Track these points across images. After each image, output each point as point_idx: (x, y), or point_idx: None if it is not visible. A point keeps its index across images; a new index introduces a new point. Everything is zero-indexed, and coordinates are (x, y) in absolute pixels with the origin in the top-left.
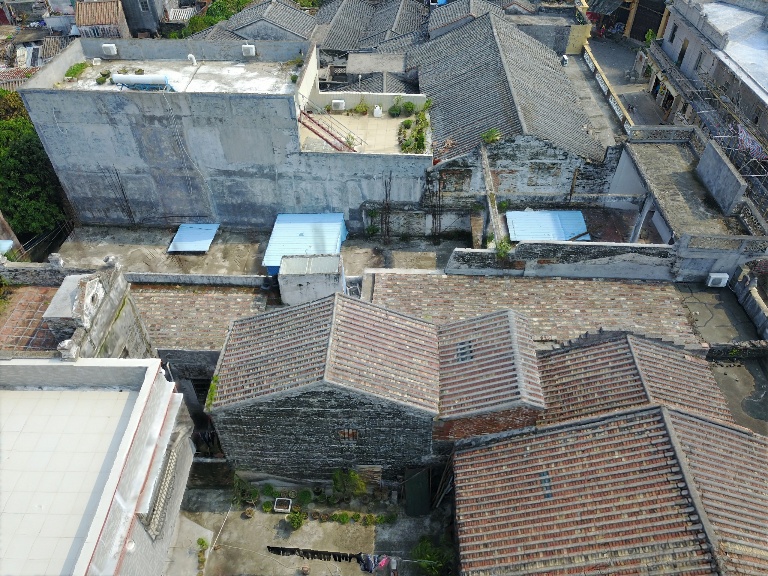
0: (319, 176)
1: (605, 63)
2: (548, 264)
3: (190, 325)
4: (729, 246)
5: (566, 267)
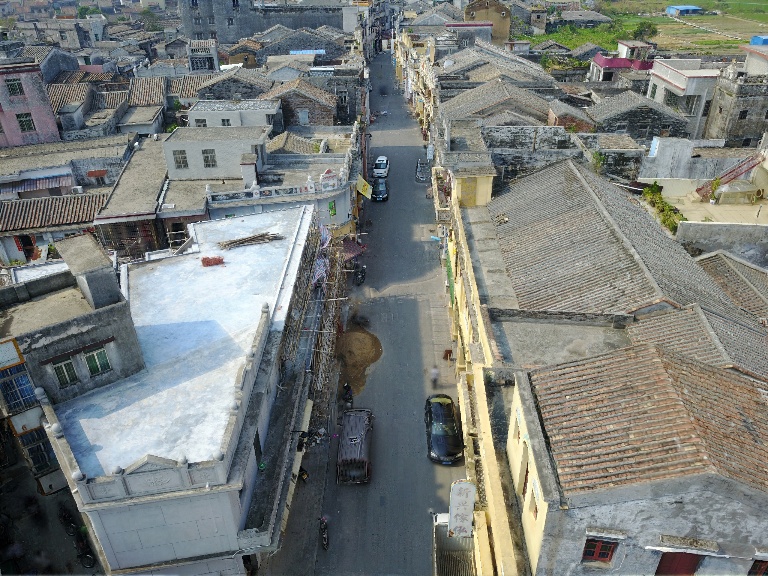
0: None
1: None
2: None
3: None
4: (457, 125)
5: None
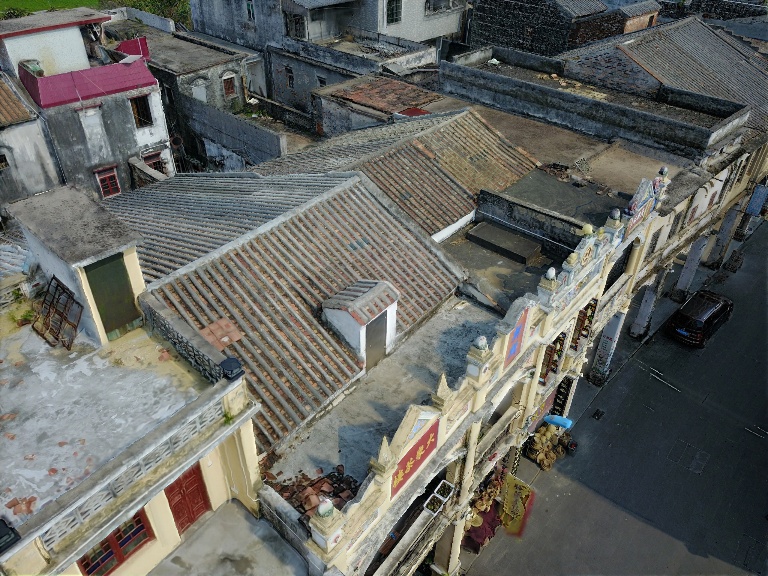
0: (613, 1)
1: None
2: (709, 19)
3: None
4: None
5: (721, 23)
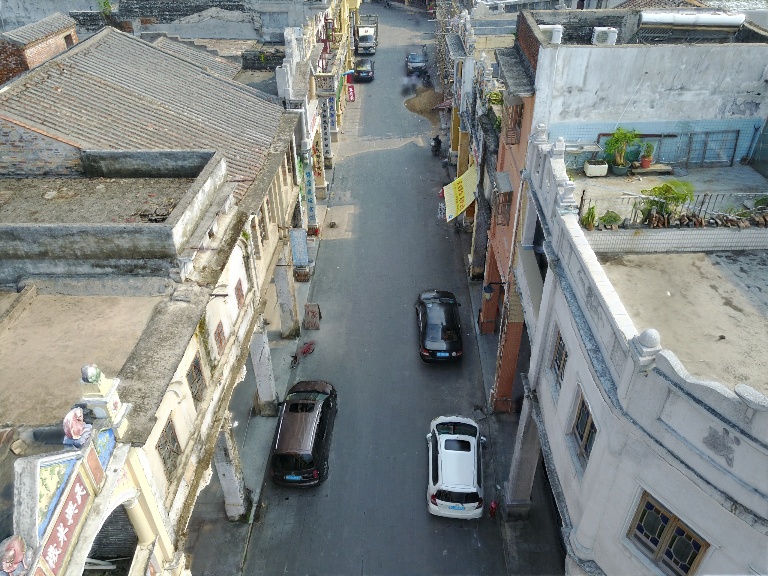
0: None
1: (424, 29)
2: (151, 24)
3: None
4: None
5: (167, 27)
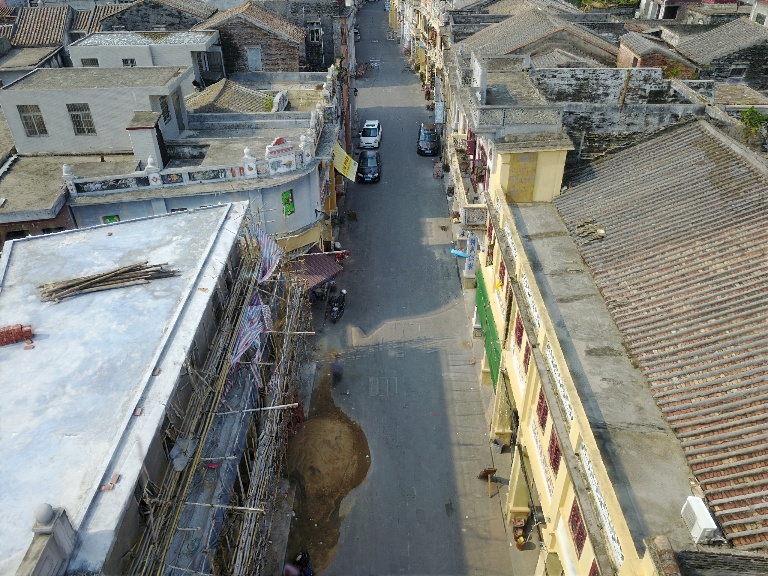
0: None
1: None
2: None
3: None
4: (489, 66)
5: None
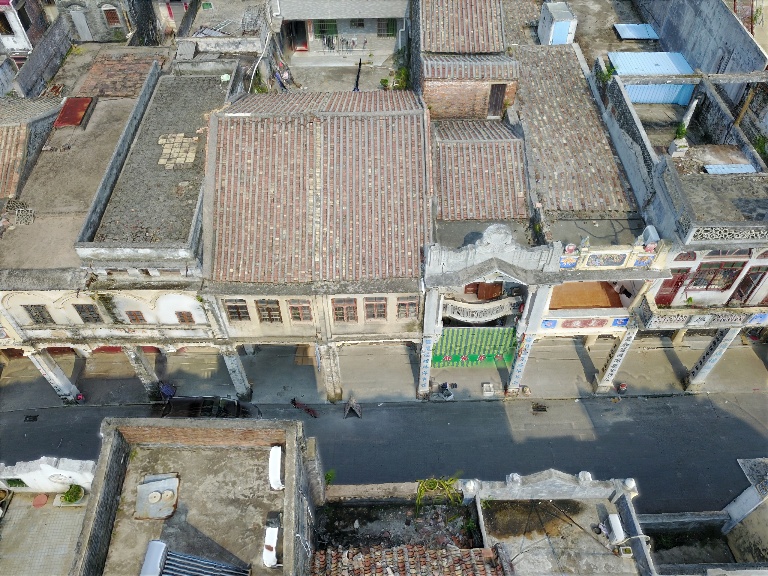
0: (713, 30)
1: None
2: None
3: (505, 4)
4: None
5: (617, 129)
